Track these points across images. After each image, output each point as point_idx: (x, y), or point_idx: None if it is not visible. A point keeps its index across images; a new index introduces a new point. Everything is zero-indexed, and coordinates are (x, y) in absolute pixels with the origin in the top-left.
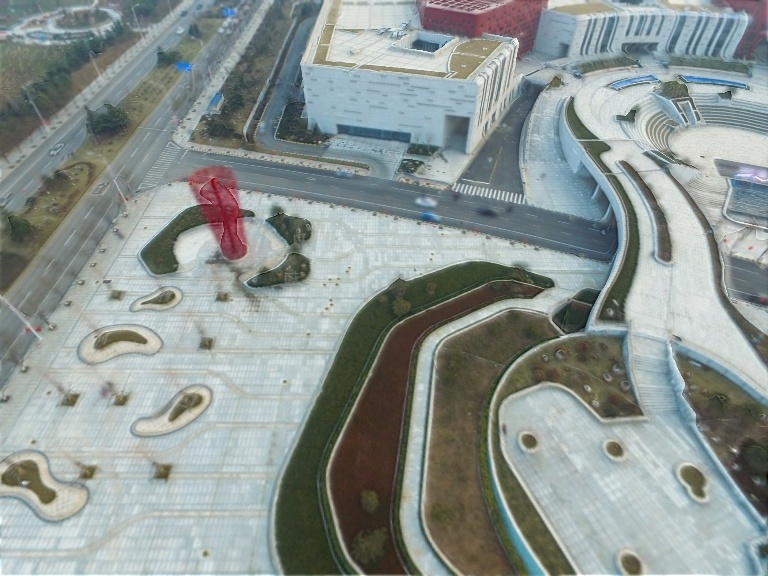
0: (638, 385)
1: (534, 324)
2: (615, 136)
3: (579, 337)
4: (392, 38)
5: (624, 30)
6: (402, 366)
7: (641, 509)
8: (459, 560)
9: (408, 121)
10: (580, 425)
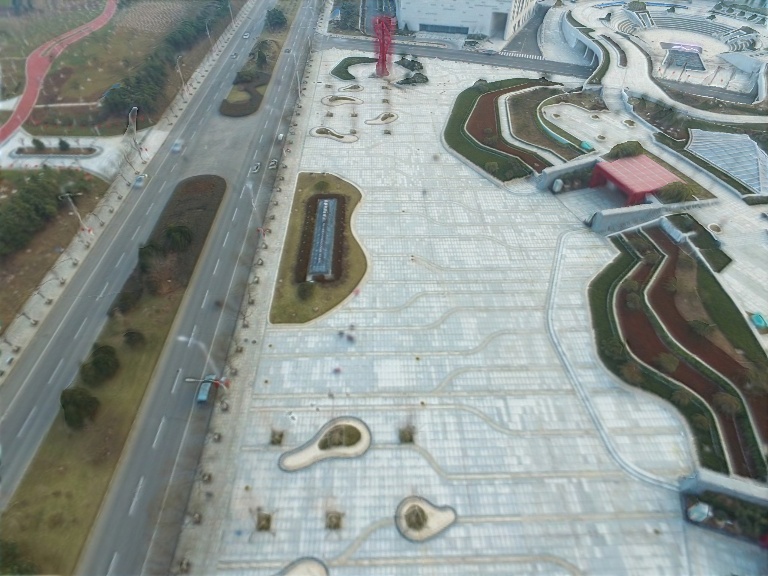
0: (607, 101)
1: None
2: (598, 26)
3: None
4: None
5: None
6: (490, 104)
7: (607, 130)
8: (530, 141)
9: (468, 18)
10: (580, 113)
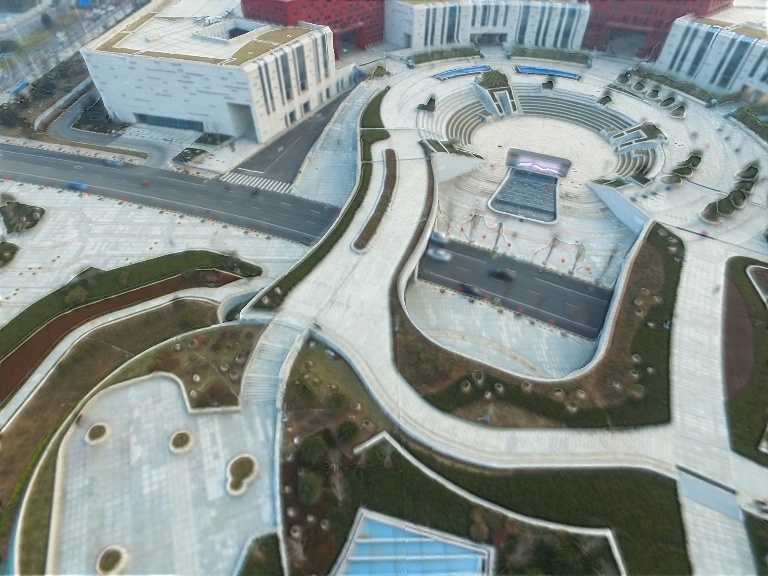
0: (248, 374)
1: (197, 313)
2: (404, 125)
3: (230, 326)
4: (205, 26)
5: (469, 20)
6: (34, 356)
7: (167, 502)
8: None
9: (195, 109)
10: (166, 416)
